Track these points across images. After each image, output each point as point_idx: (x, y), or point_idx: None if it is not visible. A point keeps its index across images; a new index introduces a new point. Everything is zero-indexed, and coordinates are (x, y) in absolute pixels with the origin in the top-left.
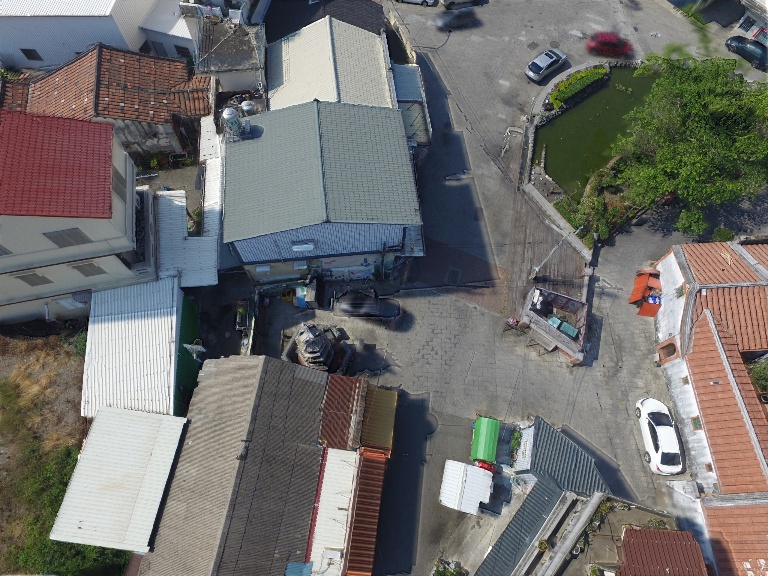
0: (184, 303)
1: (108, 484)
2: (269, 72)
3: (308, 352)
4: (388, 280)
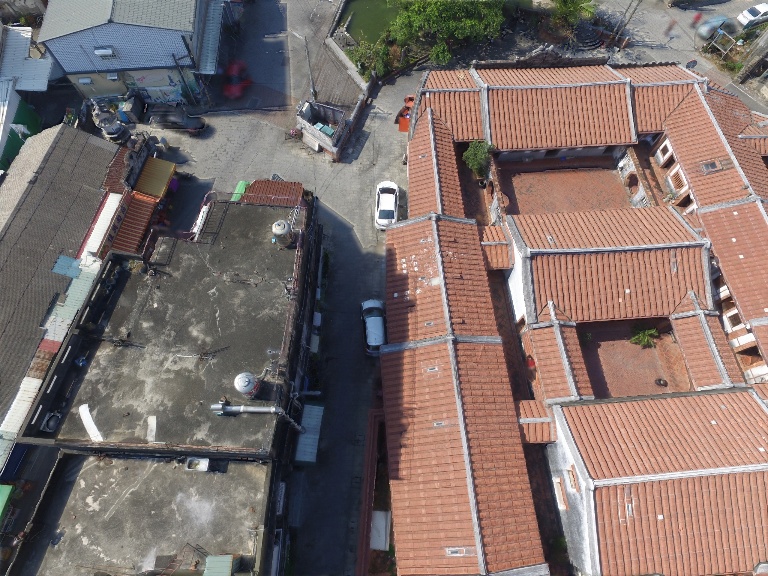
0: (21, 105)
1: None
2: None
3: (107, 133)
4: (199, 105)
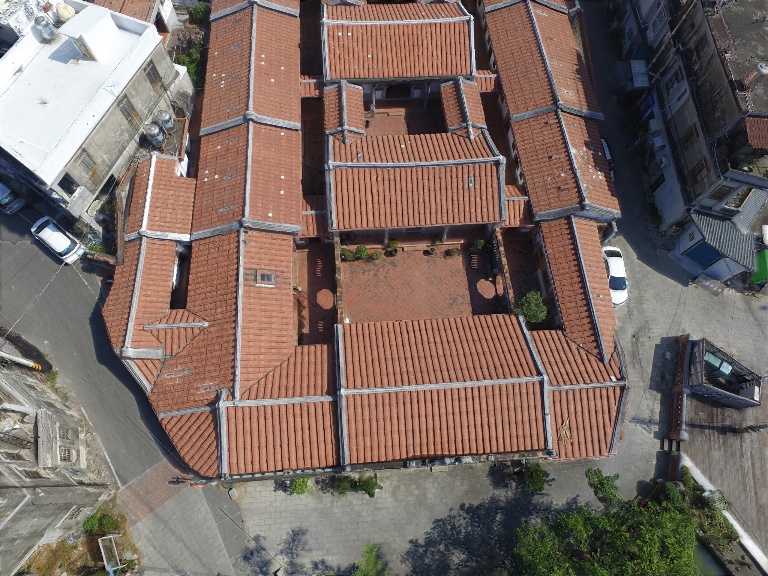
0: None
1: None
2: None
3: None
4: None
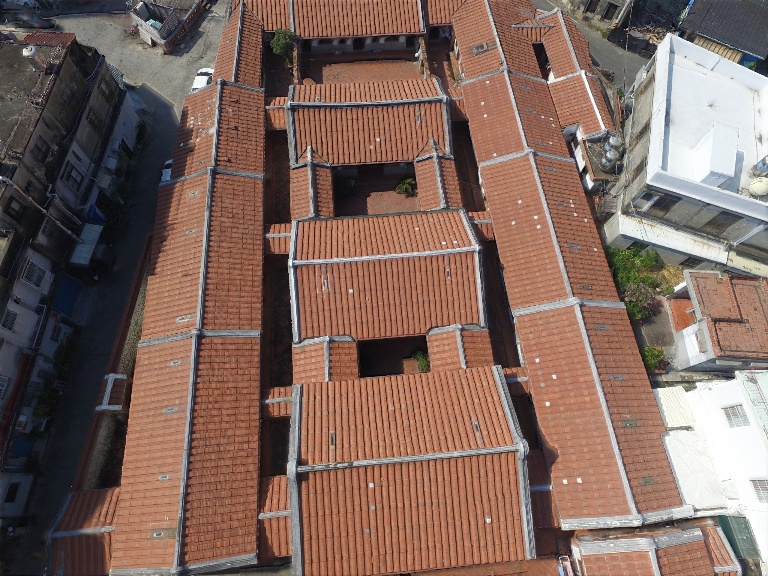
0: None
1: None
2: None
3: None
4: (53, 9)
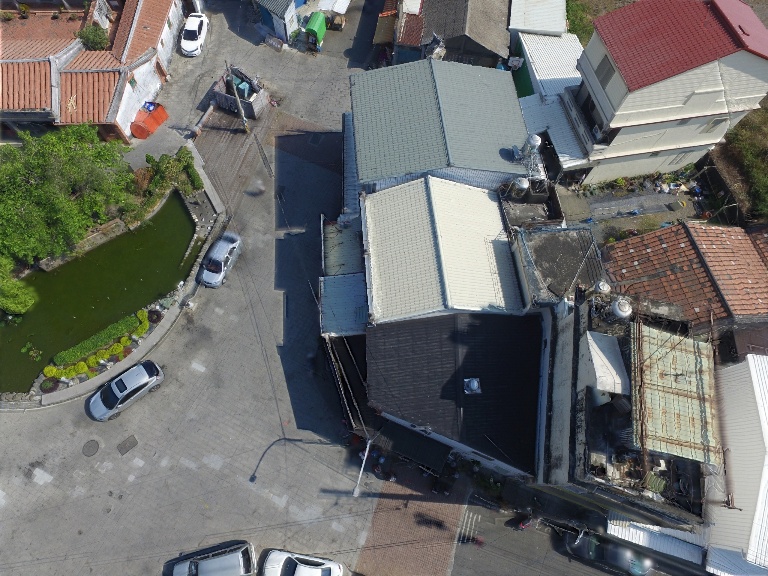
0: None
1: (544, 2)
2: (512, 268)
3: None
4: None
